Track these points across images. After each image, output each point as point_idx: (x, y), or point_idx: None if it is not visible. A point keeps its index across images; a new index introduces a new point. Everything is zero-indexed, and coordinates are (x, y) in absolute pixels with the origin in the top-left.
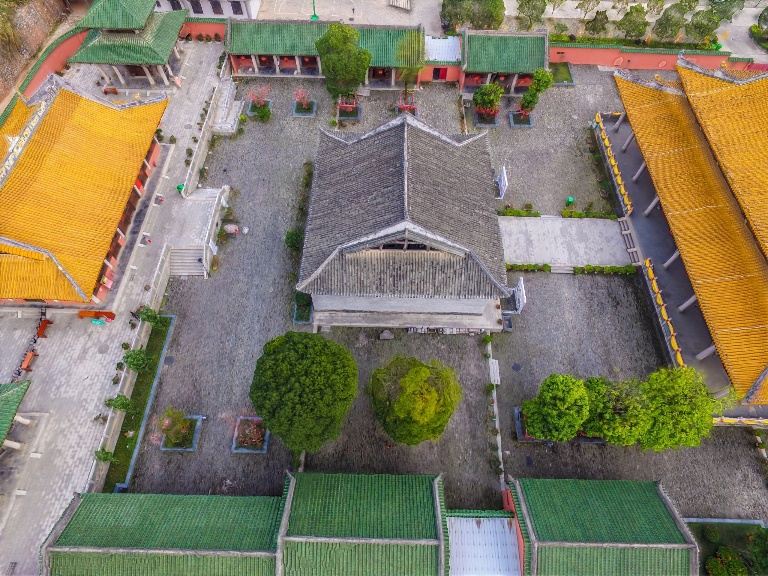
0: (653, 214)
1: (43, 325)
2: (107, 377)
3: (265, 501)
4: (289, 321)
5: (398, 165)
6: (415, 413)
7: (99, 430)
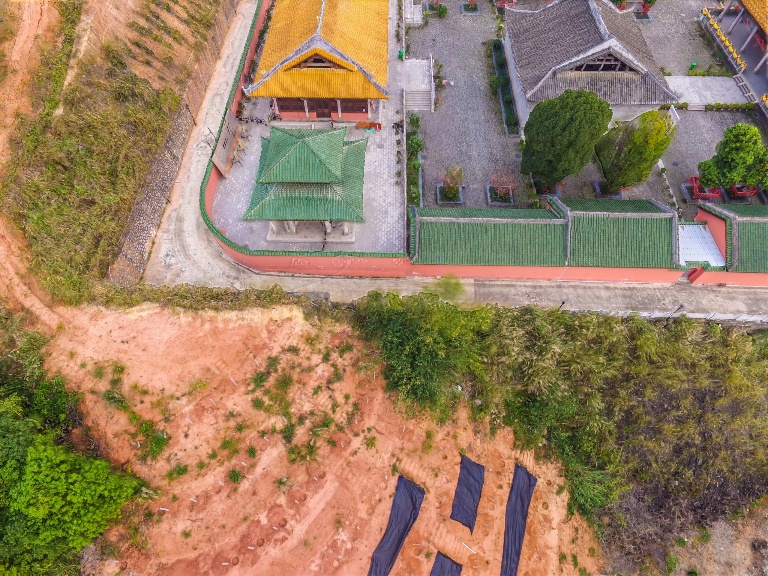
0: (761, 70)
1: None
2: (390, 161)
3: (538, 210)
4: (503, 135)
5: (587, 16)
6: (653, 133)
7: (396, 188)
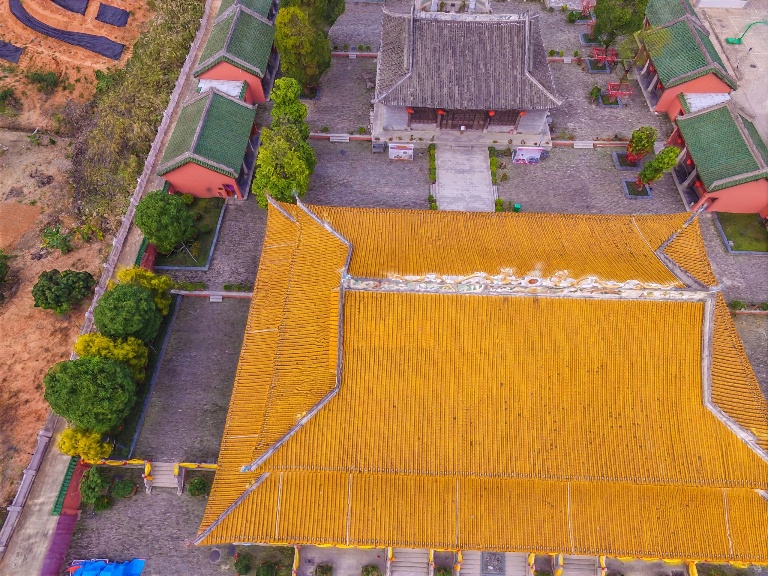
0: None
1: None
2: None
3: None
4: None
5: None
6: None
7: None
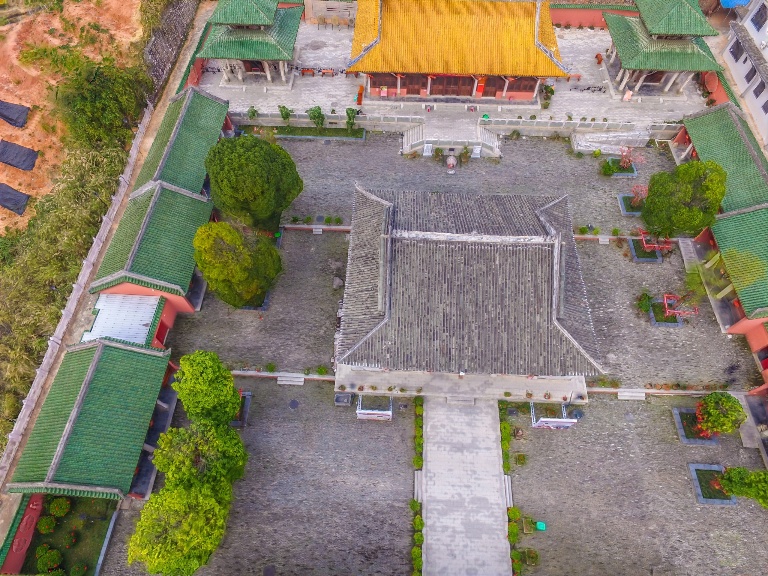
0: None
1: (353, 72)
2: None
3: (198, 187)
4: None
5: None
6: None
7: None
